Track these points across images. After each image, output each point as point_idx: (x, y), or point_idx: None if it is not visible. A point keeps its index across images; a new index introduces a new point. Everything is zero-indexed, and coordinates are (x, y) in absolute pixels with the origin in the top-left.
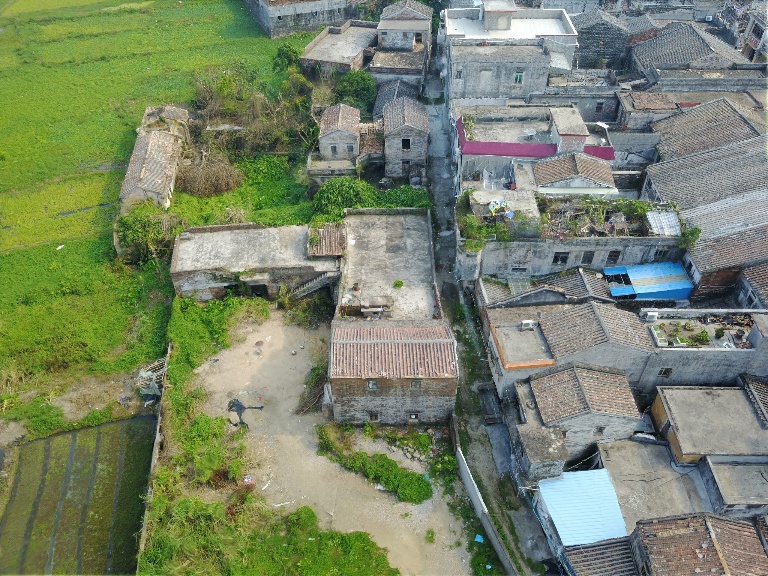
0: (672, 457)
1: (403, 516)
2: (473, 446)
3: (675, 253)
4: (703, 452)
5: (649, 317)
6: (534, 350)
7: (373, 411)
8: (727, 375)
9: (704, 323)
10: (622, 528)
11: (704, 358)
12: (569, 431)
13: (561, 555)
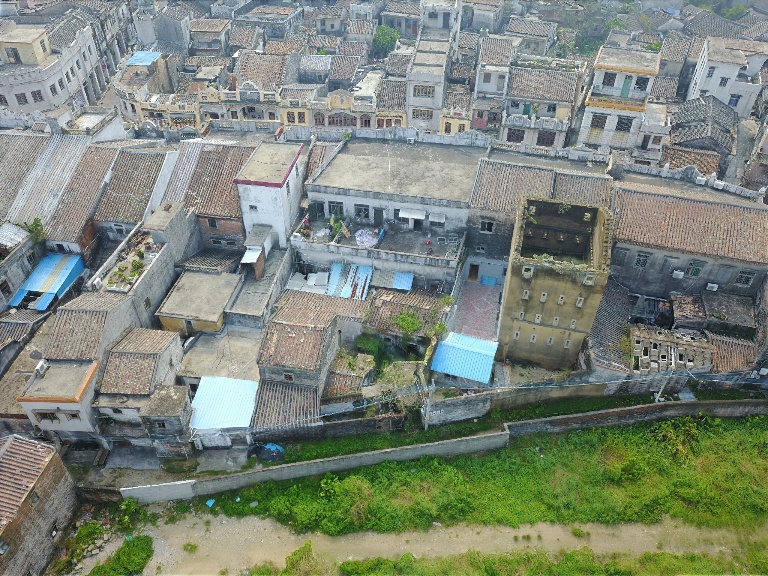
0: (212, 335)
1: (158, 572)
2: (119, 485)
3: (39, 250)
4: (221, 311)
5: (97, 285)
6: (73, 373)
7: (23, 573)
8: (170, 273)
9: (124, 260)
10: (251, 383)
11: (154, 273)
12: (162, 383)
13: (252, 436)
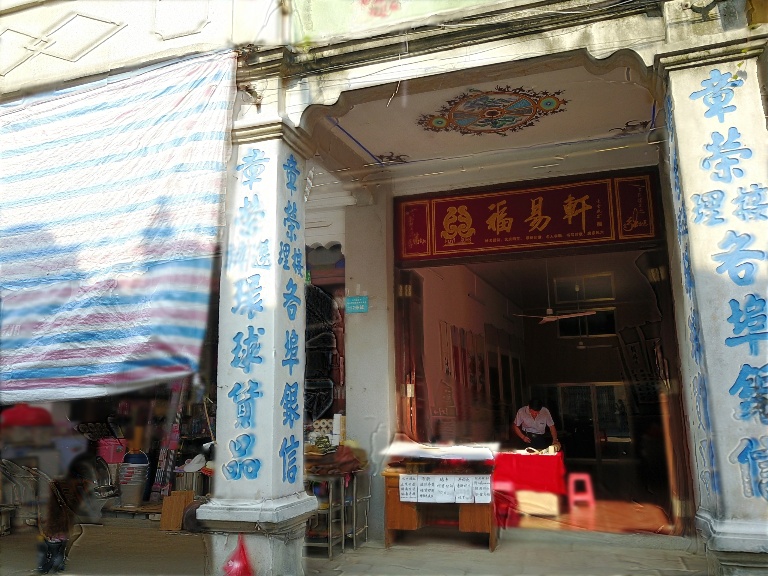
0: None
1: None
2: None
3: None
4: None
5: None
6: None
7: None
8: None
9: None
10: None
11: None
12: None
13: None
